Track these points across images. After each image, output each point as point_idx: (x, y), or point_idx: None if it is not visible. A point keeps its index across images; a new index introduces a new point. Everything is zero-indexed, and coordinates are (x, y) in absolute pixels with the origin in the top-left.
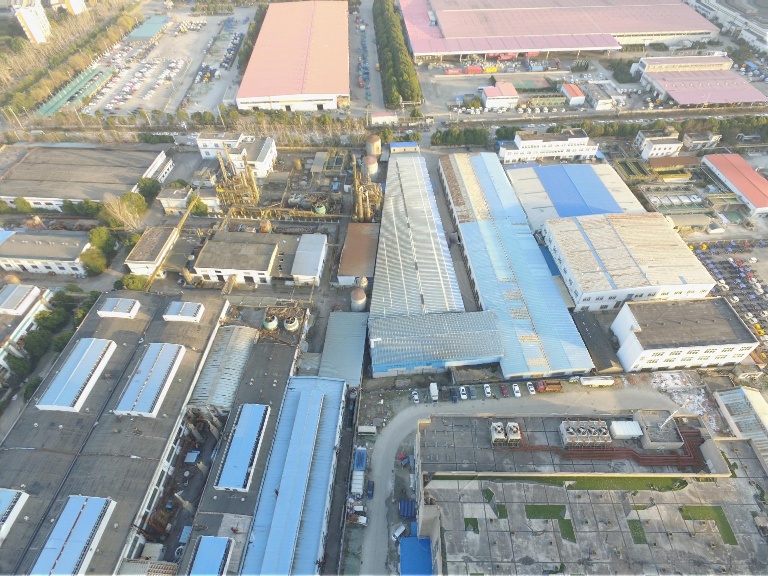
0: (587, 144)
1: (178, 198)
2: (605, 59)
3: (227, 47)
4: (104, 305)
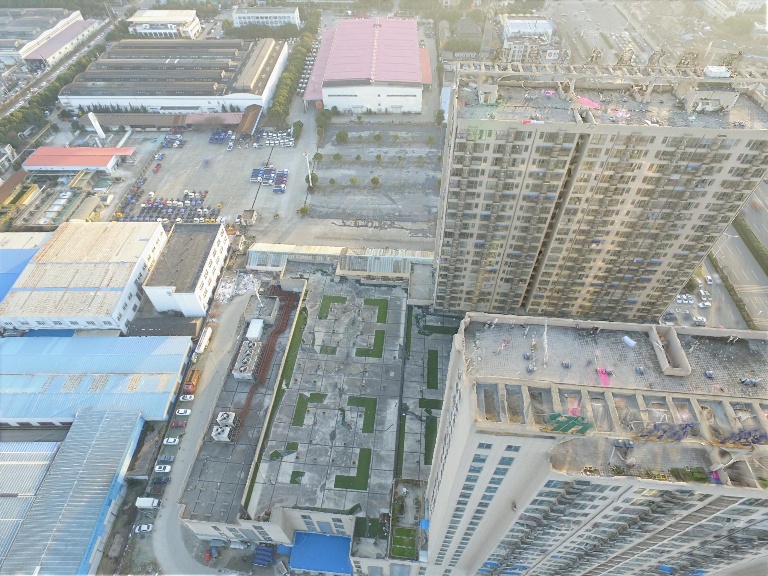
0: None
1: None
2: None
3: None
4: None
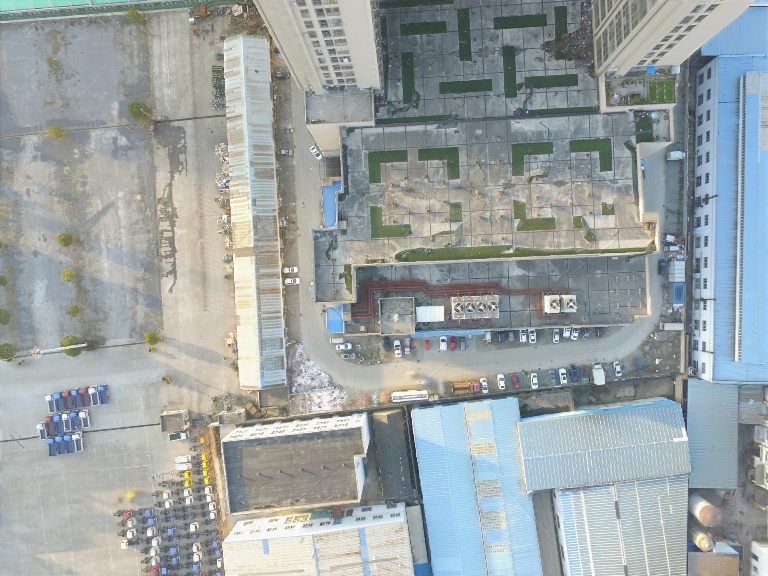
0: None
1: None
2: None
3: None
4: None
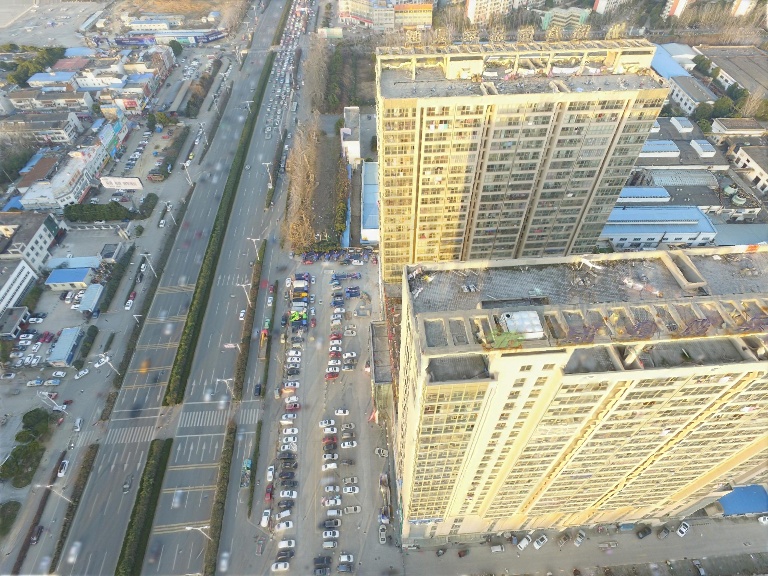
0: None
1: None
2: None
3: None
4: (679, 117)
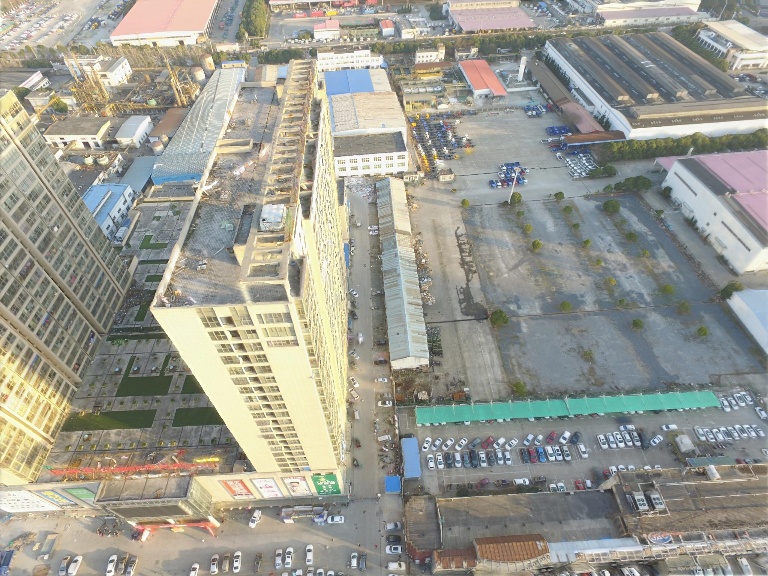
0: (371, 56)
1: (42, 97)
2: (431, 4)
3: (118, 4)
4: None
